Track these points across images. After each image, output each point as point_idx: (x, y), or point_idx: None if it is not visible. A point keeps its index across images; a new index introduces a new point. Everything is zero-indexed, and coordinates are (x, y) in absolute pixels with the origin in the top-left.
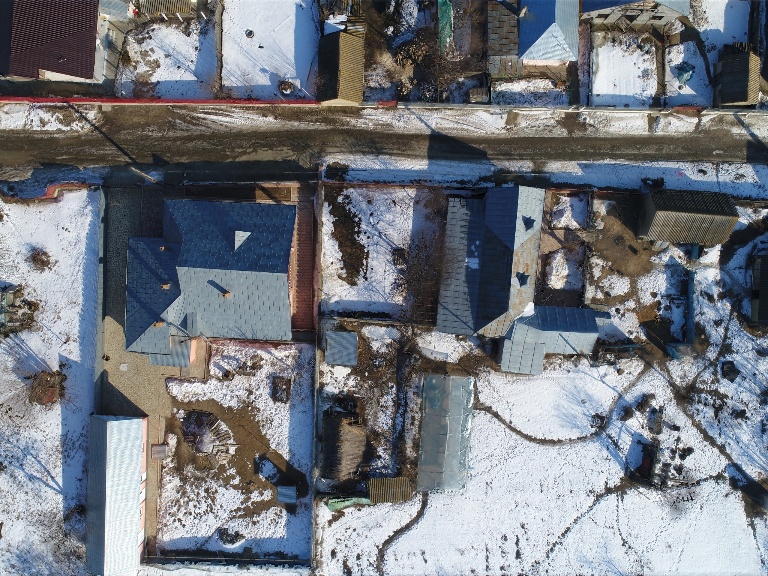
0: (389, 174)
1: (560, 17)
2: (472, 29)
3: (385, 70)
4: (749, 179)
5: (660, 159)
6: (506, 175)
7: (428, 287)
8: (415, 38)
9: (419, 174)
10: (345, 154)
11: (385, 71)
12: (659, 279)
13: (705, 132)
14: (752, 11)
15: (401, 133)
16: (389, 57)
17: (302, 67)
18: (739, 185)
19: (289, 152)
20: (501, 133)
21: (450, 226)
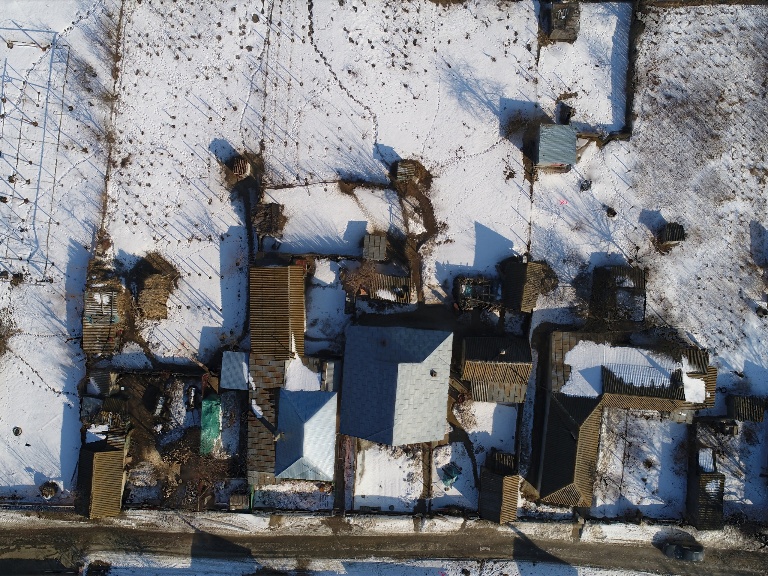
0: (151, 572)
1: (310, 449)
2: (241, 428)
3: (152, 467)
4: None
5: (425, 557)
6: (269, 573)
7: None
8: (180, 441)
9: (182, 572)
10: (108, 552)
11: (152, 468)
12: None
13: (471, 530)
14: (518, 418)
15: (165, 532)
16: (157, 455)
17: (67, 467)
18: None
19: (52, 550)
20: (265, 532)
21: None
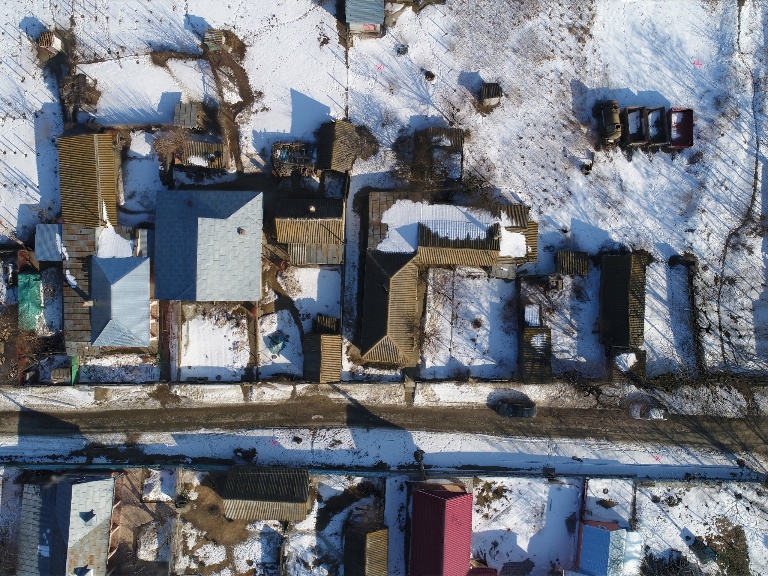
0: None
1: (119, 312)
2: None
3: None
4: (345, 445)
5: (257, 427)
6: (98, 449)
7: (5, 572)
8: None
9: (9, 450)
10: None
11: None
12: (254, 547)
13: (302, 398)
14: None
15: None
16: None
17: None
18: (333, 453)
19: None
20: (92, 407)
21: (25, 512)
